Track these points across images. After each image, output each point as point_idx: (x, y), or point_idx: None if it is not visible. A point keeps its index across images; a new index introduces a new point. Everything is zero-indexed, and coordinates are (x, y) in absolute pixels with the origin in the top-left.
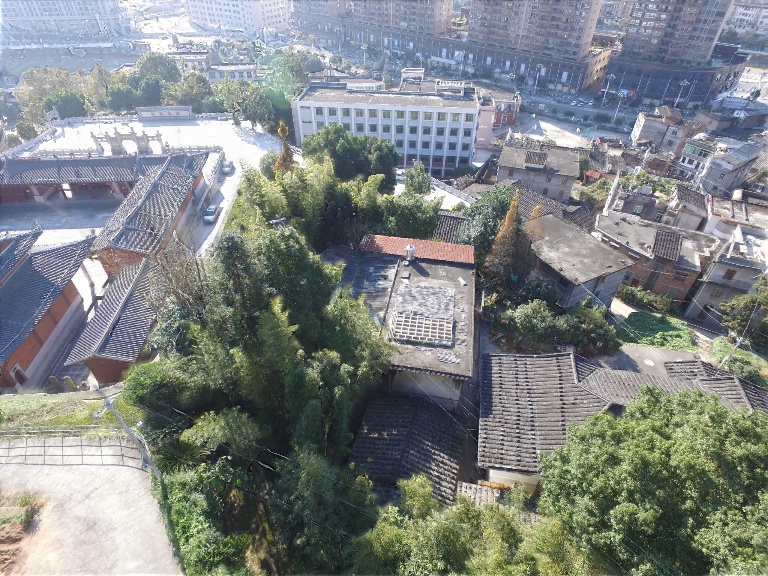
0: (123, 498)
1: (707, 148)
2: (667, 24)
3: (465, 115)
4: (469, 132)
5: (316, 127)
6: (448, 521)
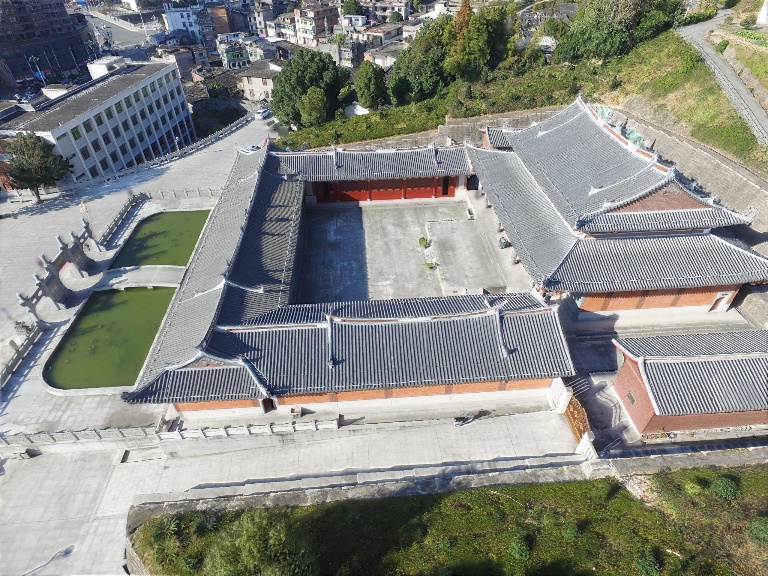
0: (691, 29)
1: (239, 49)
2: (10, 0)
3: (171, 73)
4: (178, 90)
5: (81, 158)
6: None
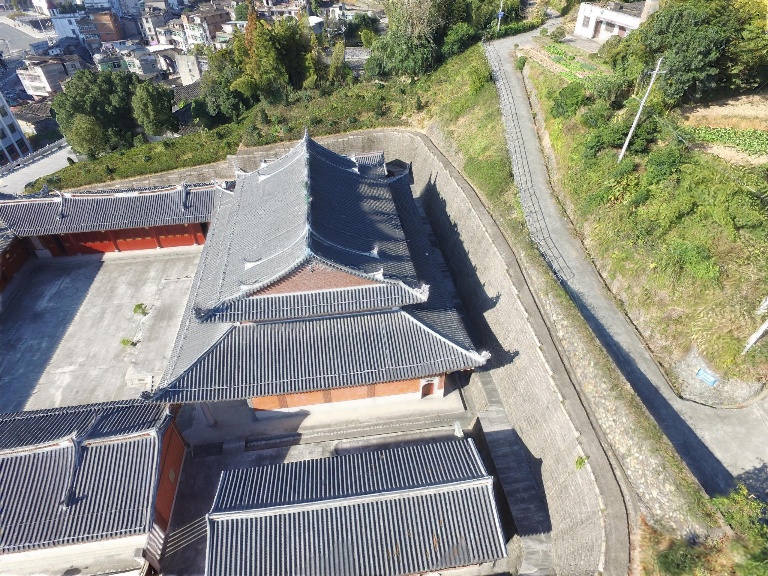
0: (504, 42)
1: (116, 60)
2: None
3: None
4: (3, 111)
5: None
6: (493, 3)
